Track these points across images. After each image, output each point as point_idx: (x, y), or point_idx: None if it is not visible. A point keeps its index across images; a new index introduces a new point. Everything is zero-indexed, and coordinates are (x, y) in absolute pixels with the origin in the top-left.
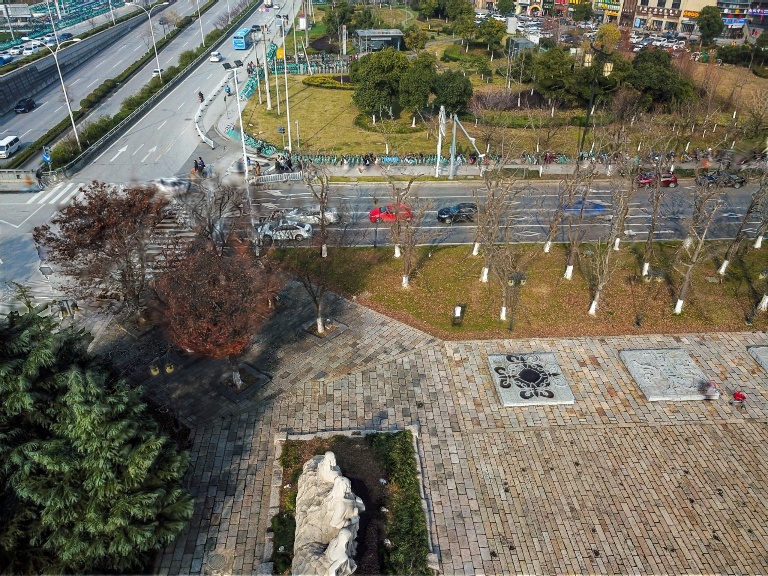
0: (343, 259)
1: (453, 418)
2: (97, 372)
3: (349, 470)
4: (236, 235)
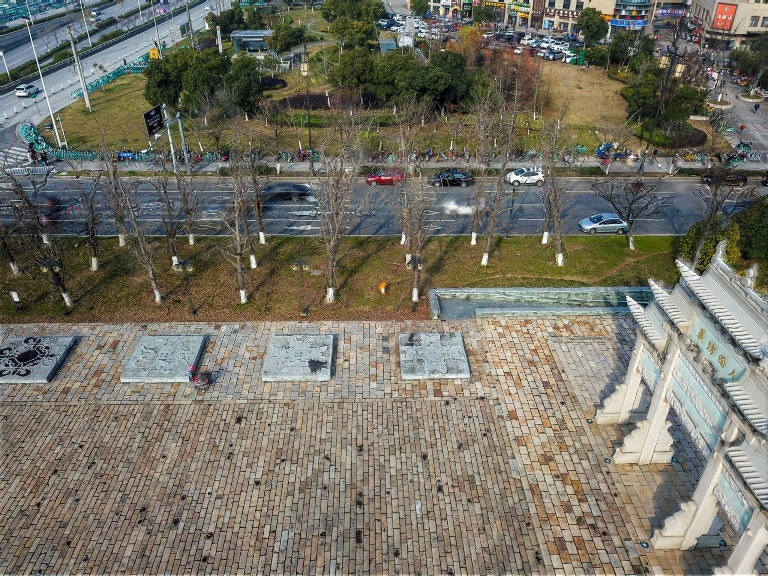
0: None
1: None
2: None
3: None
4: None
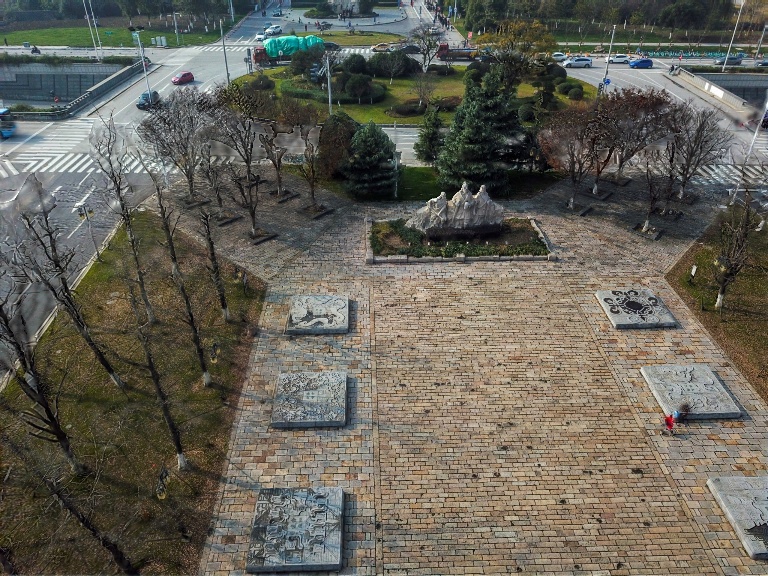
0: (760, 238)
1: (574, 274)
2: (511, 132)
3: (512, 235)
4: (763, 199)
